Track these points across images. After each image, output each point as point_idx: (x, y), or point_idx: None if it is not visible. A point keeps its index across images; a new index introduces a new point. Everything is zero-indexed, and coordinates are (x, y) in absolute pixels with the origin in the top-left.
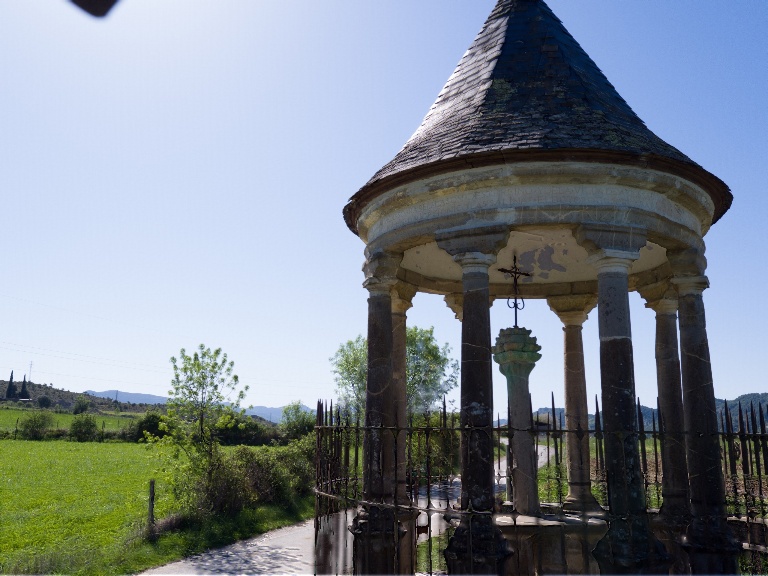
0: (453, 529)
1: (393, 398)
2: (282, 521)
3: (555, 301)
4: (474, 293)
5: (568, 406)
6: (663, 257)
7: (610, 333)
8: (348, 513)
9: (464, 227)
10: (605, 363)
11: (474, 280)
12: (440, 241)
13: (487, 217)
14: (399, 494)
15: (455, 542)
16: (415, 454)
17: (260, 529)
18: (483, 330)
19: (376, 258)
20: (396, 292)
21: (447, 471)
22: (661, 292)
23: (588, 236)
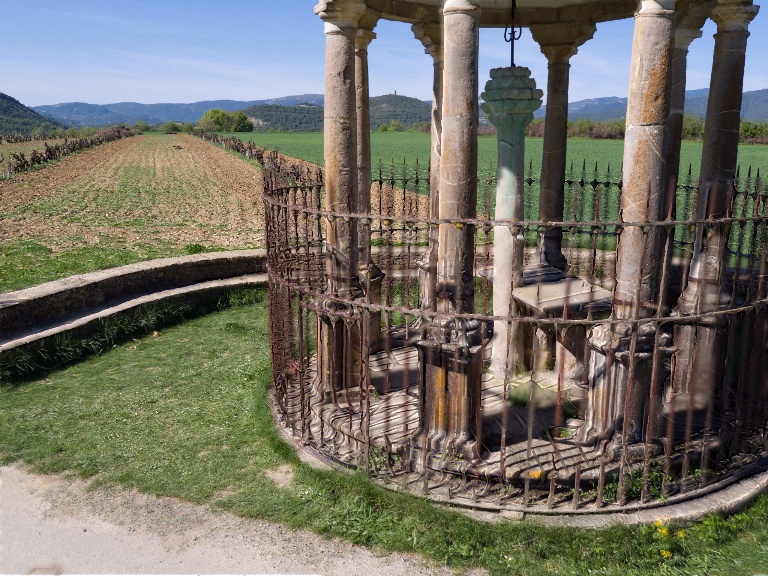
0: None
1: None
2: None
3: None
4: None
5: (365, 156)
6: None
7: None
8: None
9: None
10: None
11: None
12: None
13: None
14: None
15: None
16: None
17: None
18: None
19: None
20: None
21: None
22: None
23: None
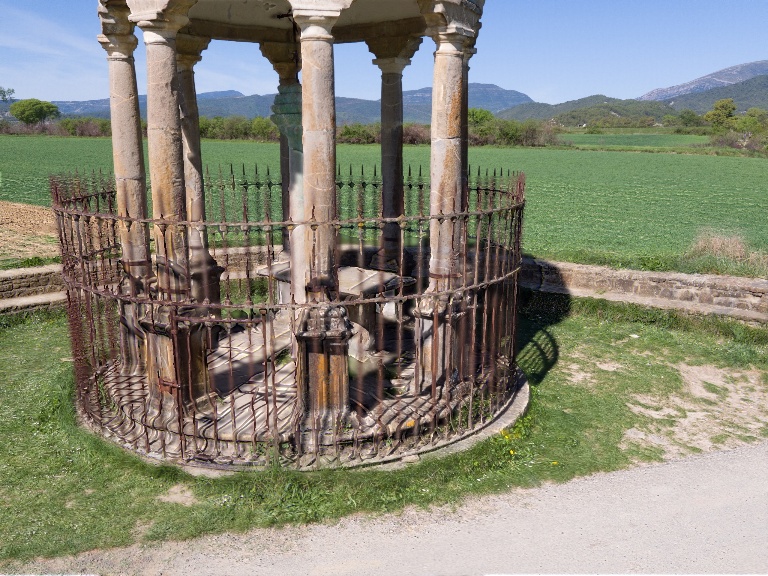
0: None
1: None
2: None
3: None
4: None
5: None
6: (204, 12)
7: None
8: None
9: None
10: None
11: None
12: None
13: None
14: None
15: None
16: None
17: None
18: None
19: None
20: None
21: None
22: (198, 48)
23: None
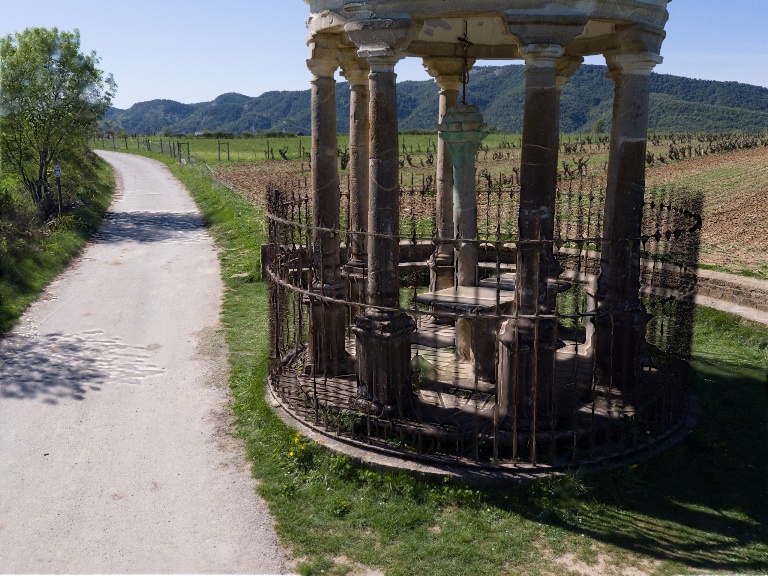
0: (234, 279)
1: (330, 178)
2: (24, 297)
3: (440, 62)
4: (549, 91)
5: (445, 171)
6: None
7: (638, 135)
8: (79, 272)
9: (545, 11)
10: (629, 162)
11: (550, 76)
12: (515, 24)
13: (570, 3)
14: (338, 278)
15: (524, 335)
16: (63, 184)
17: (14, 313)
18: (553, 132)
19: (404, 26)
20: (336, 52)
21: (102, 201)
22: None
23: (643, 37)
